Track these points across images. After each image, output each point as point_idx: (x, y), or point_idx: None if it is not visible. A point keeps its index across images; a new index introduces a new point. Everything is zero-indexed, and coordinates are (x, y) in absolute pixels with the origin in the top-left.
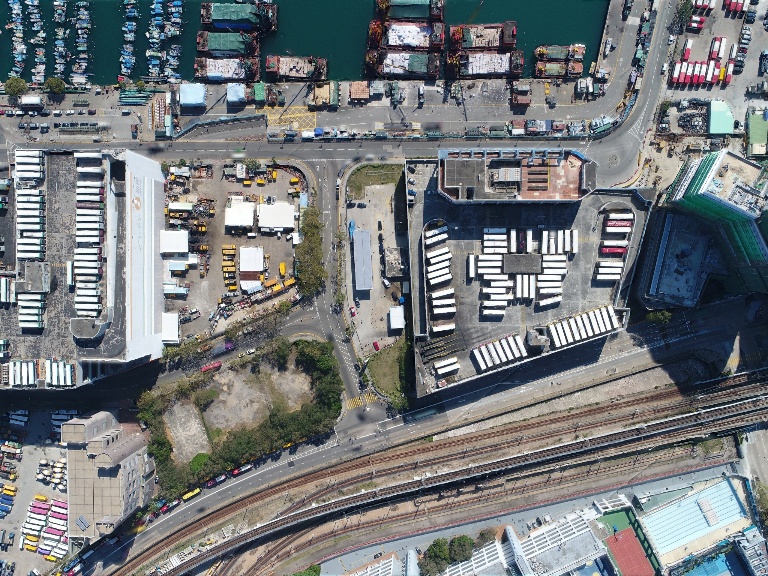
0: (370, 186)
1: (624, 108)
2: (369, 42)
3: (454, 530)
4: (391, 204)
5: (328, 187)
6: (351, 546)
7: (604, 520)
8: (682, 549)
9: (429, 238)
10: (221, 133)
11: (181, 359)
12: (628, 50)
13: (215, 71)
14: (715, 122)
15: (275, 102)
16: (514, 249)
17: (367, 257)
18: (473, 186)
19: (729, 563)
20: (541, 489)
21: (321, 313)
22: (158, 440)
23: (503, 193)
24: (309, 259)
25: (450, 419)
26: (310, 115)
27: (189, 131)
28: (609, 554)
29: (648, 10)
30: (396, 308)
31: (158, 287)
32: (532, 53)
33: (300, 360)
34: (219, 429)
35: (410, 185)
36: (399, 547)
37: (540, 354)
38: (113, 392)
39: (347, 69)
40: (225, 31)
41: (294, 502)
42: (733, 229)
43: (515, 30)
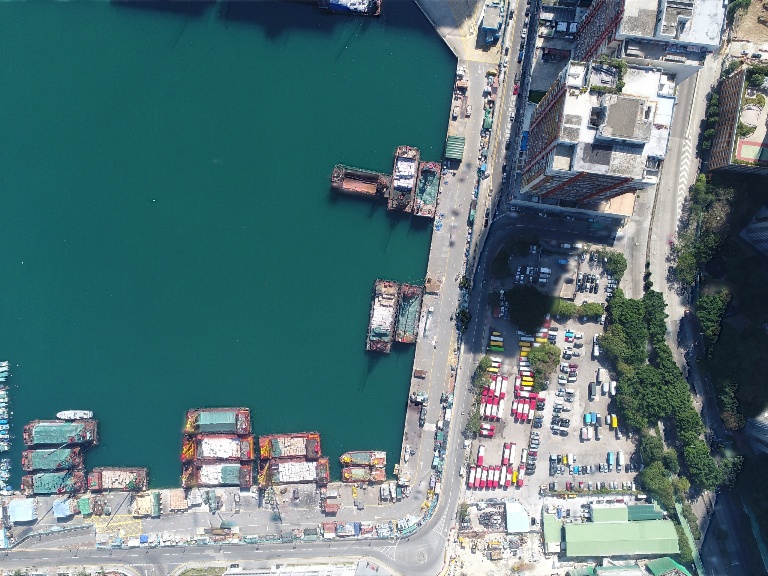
0: None
1: (427, 510)
2: None
3: None
4: None
5: None
6: None
7: None
8: None
9: None
10: (53, 542)
11: None
12: (427, 454)
13: (42, 488)
14: (511, 523)
15: (101, 512)
16: None
17: None
18: None
19: None
20: None
21: None
22: None
23: None
24: None
25: None
26: (135, 522)
27: (23, 541)
28: None
29: (443, 417)
30: None
31: None
32: None
33: None
34: None
35: None
36: None
37: None
38: None
39: (167, 477)
40: (50, 445)
41: None
42: None
43: (316, 448)
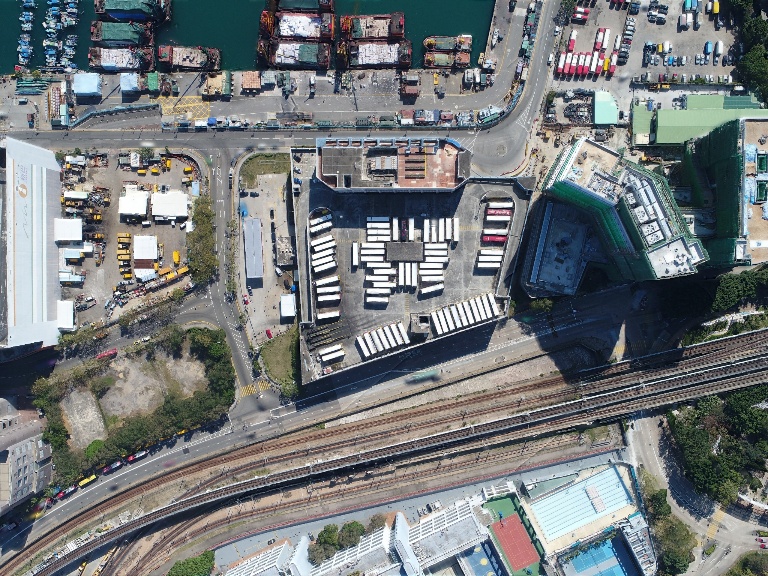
0: (262, 175)
1: (511, 98)
2: (261, 32)
3: (346, 516)
4: (283, 193)
5: (221, 176)
6: (245, 532)
7: (490, 506)
8: (569, 535)
9: (314, 226)
10: (116, 122)
11: (78, 347)
12: (515, 41)
13: (109, 61)
14: (599, 112)
15: (169, 92)
16: (396, 237)
17: (258, 245)
18: (350, 174)
19: (616, 549)
20: (431, 476)
21: (215, 301)
22: (53, 427)
23: (379, 181)
24: (198, 247)
25: (342, 406)
26: (204, 105)
27: (85, 120)
28: (495, 540)
29: (534, 1)
30: (287, 296)
31: (52, 275)
32: (422, 44)
33: (195, 348)
34: (115, 416)
35: (296, 174)
36: (292, 533)
37: (424, 341)
38: (11, 379)
39: (240, 59)
40: (120, 21)
41: (189, 489)
42: (603, 217)
43: (402, 21)
